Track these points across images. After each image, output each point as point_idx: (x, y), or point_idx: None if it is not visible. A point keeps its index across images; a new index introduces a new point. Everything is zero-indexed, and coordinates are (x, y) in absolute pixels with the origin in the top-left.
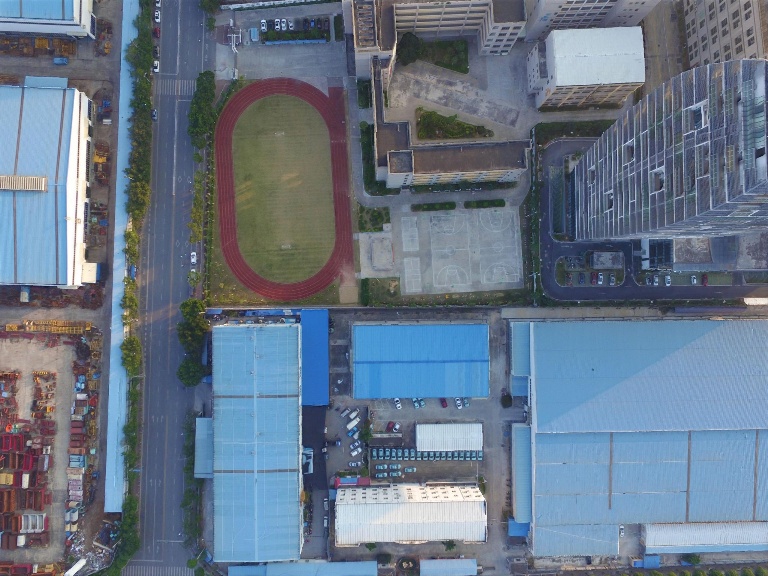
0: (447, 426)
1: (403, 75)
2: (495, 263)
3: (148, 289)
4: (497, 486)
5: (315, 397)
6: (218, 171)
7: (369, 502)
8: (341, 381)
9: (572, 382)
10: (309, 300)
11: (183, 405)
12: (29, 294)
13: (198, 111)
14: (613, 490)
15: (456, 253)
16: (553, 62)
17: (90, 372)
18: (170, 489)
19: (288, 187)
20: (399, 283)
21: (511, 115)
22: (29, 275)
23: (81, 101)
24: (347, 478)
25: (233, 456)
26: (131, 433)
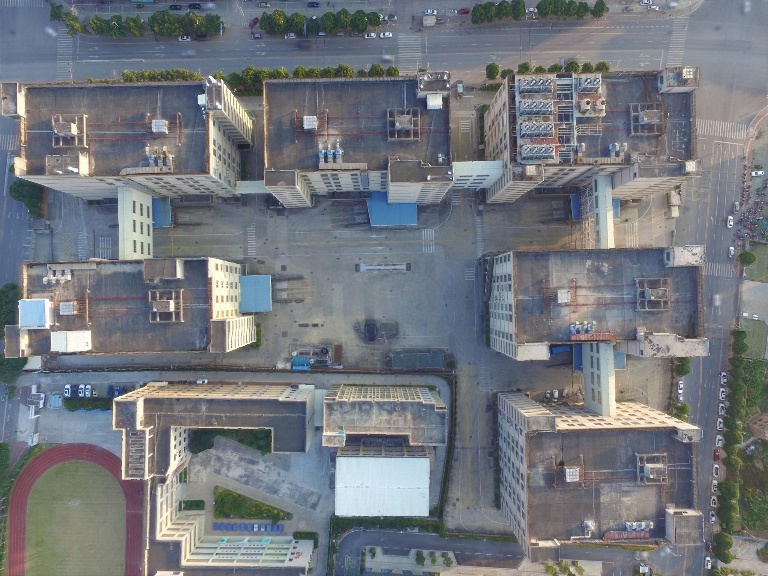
0: None
1: (205, 450)
2: None
3: None
4: None
5: None
6: (10, 535)
7: None
8: None
9: None
10: None
11: None
12: None
13: None
14: None
15: None
16: None
17: None
18: None
19: (80, 556)
20: None
21: (312, 498)
22: None
23: None
24: None
25: None
26: None
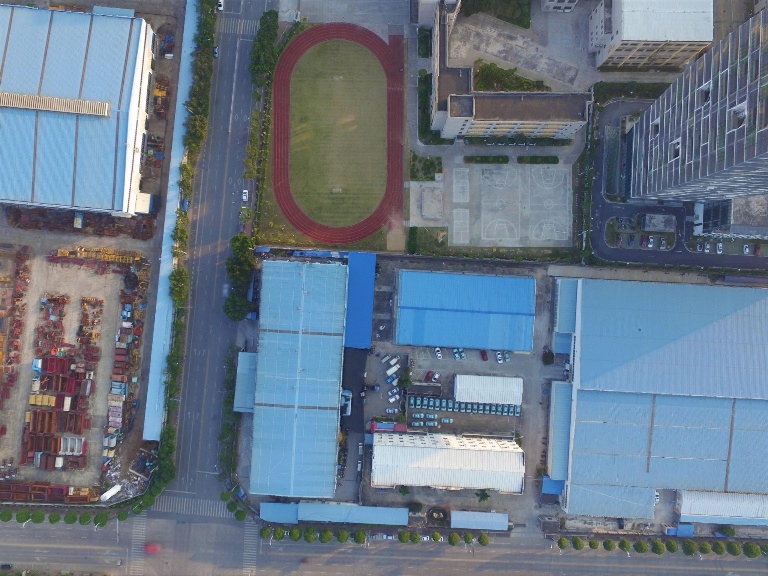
0: (487, 378)
1: (464, 27)
2: (545, 220)
3: (198, 224)
4: (533, 443)
5: (358, 340)
6: (275, 111)
7: (407, 445)
8: (383, 327)
9: (618, 341)
10: (356, 245)
11: (225, 340)
12: (82, 221)
13: (260, 49)
14: (652, 453)
15: (506, 207)
16: (620, 16)
17: (137, 301)
18: (207, 423)
19: (343, 131)
20: (447, 233)
21: (570, 73)
22: (86, 199)
23: (147, 32)
24: (384, 423)
25: (275, 390)
26: (174, 362)
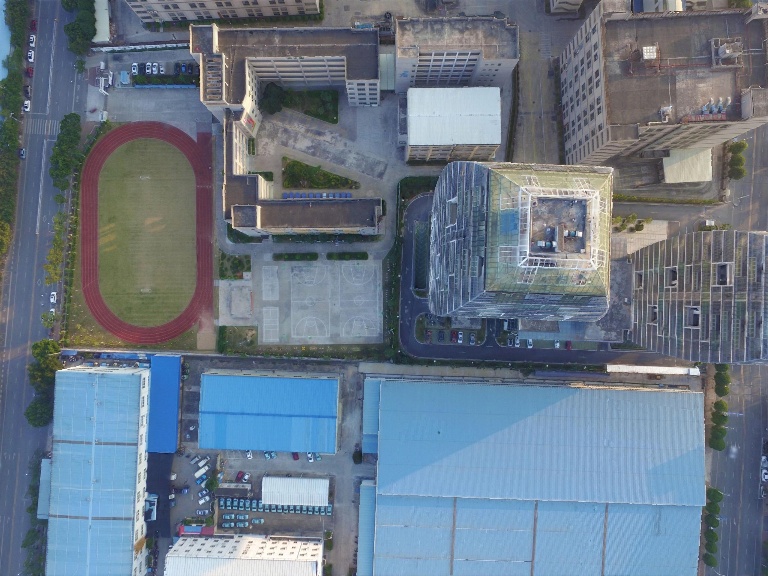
0: (293, 480)
1: (271, 123)
2: (355, 316)
3: (8, 326)
4: (345, 542)
5: (161, 444)
6: (83, 212)
7: (200, 556)
8: (193, 428)
9: (417, 444)
10: (166, 345)
11: (36, 444)
12: None
13: (60, 153)
14: (455, 556)
15: (316, 304)
16: None
17: None
18: (18, 527)
19: (151, 231)
20: (257, 332)
21: (379, 167)
22: None
23: None
24: (192, 526)
25: (69, 501)
26: None
